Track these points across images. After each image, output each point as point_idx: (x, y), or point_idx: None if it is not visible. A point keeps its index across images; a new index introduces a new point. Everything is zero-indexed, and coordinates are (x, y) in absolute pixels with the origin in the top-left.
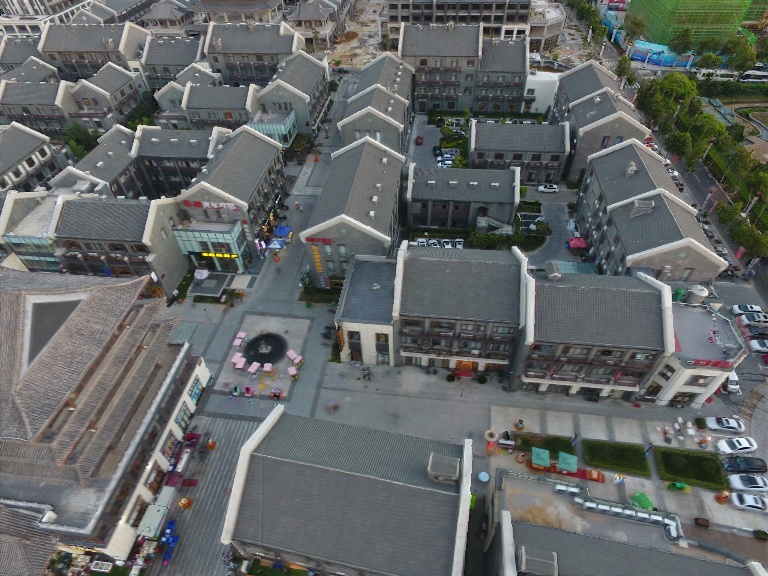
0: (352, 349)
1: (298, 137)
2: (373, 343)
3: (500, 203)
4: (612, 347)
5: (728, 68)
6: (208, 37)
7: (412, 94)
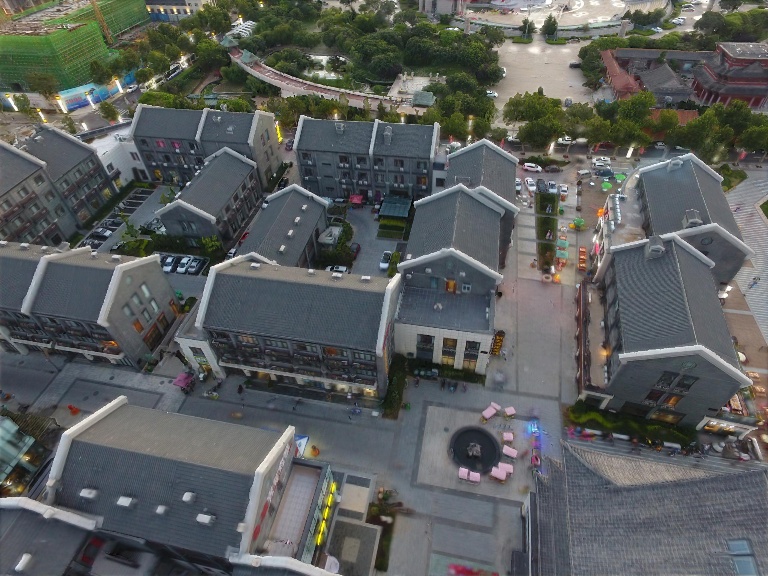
0: None
1: None
2: None
3: None
4: None
5: (158, 74)
6: None
7: None
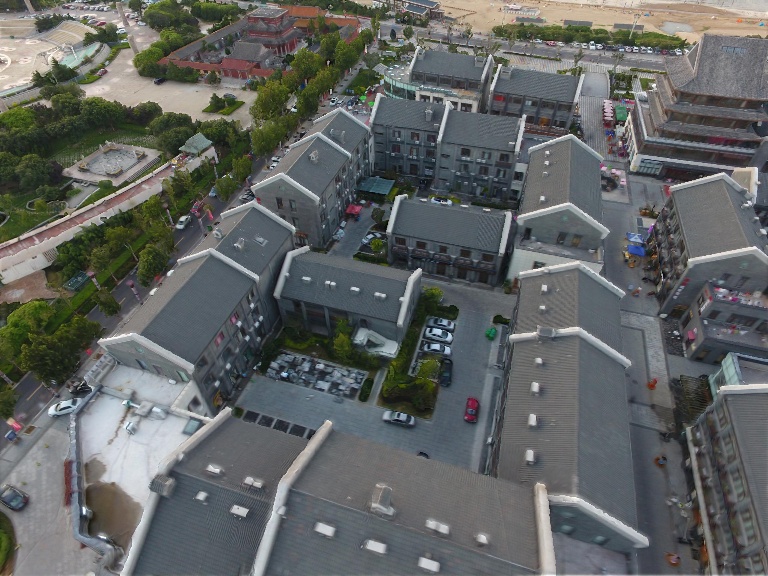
0: None
1: None
2: None
3: None
4: None
5: None
6: None
7: None
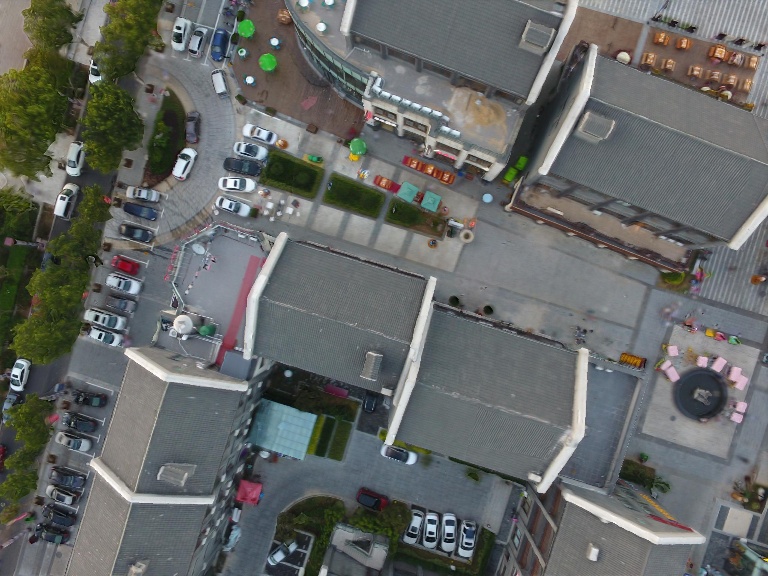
0: None
1: None
2: None
3: None
4: None
5: None
6: None
7: None
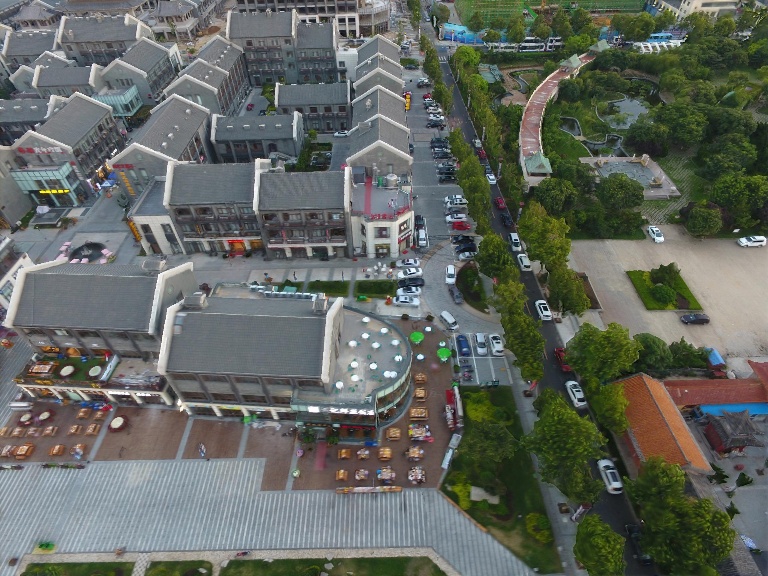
0: (151, 242)
1: (143, 108)
2: (163, 234)
3: (283, 139)
4: (311, 210)
5: (507, 41)
6: (61, 29)
7: (246, 71)
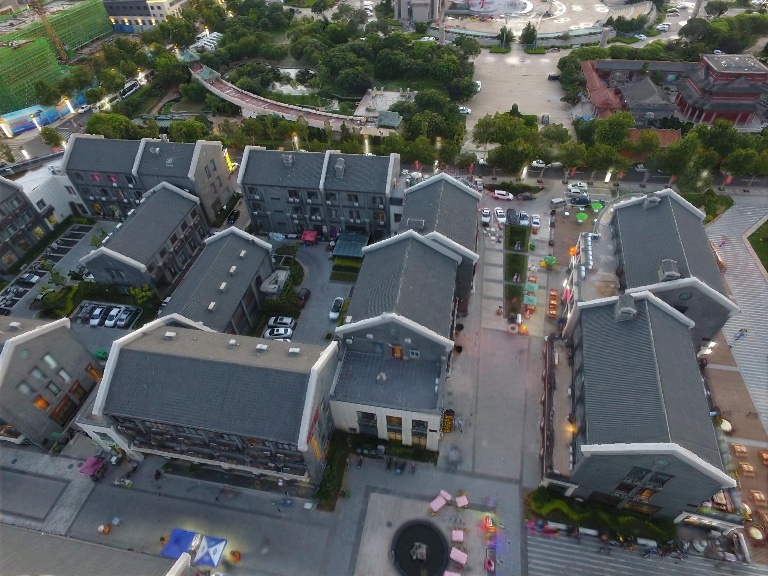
0: None
1: None
2: None
3: (262, 261)
4: None
5: (111, 93)
6: None
7: None
